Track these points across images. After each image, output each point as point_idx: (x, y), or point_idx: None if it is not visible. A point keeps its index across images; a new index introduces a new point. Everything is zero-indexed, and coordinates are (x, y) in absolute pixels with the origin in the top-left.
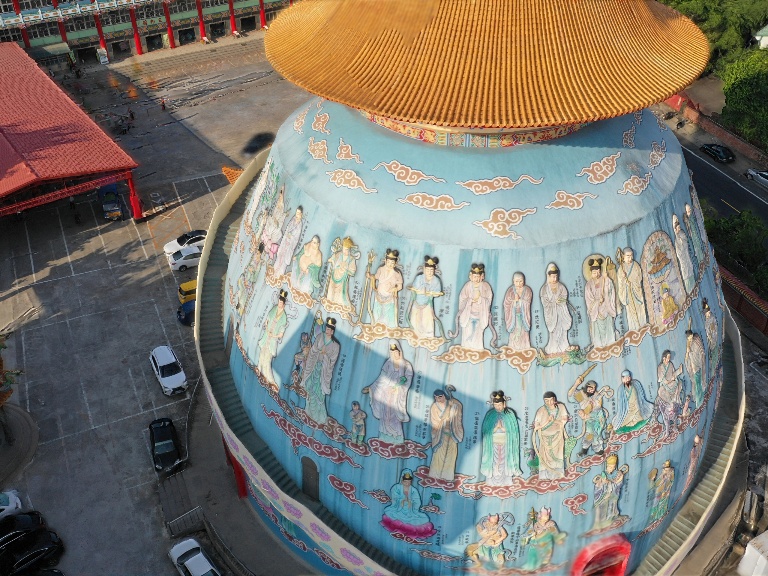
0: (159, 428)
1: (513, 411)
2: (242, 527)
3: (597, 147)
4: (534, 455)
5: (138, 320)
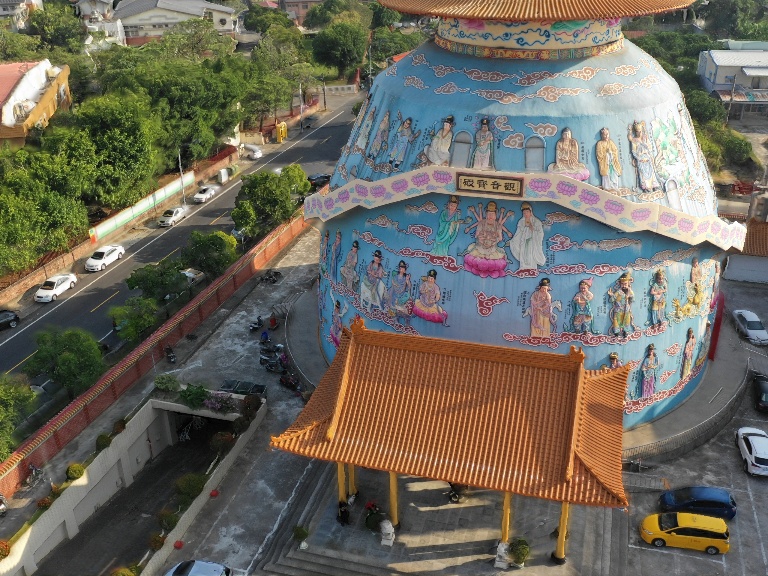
0: None
1: None
2: None
3: None
4: None
5: None
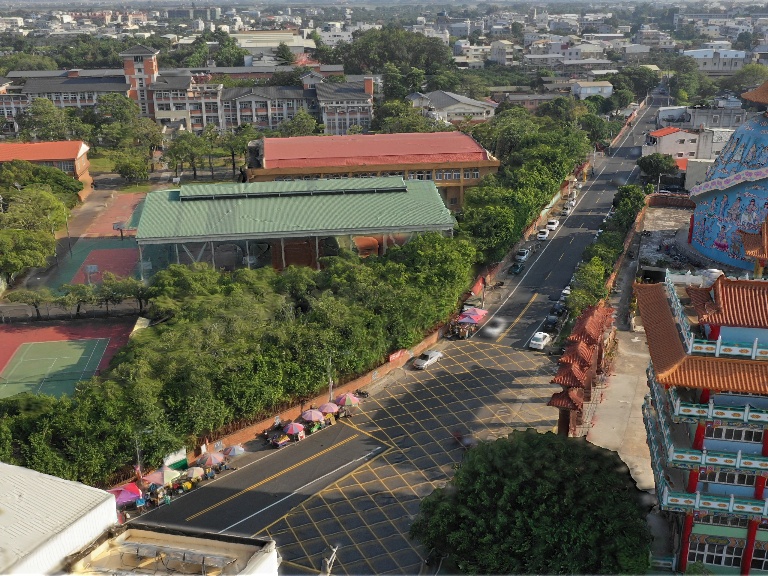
0: None
1: None
2: None
3: None
4: None
5: None
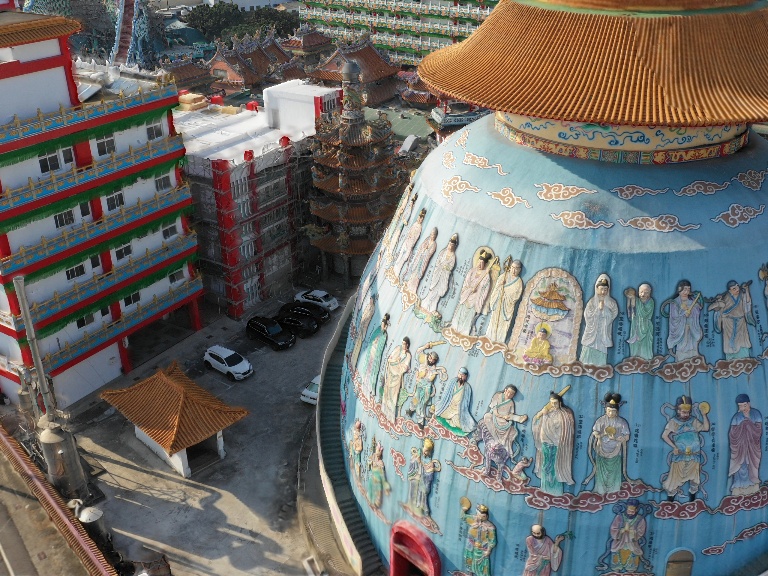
0: None
1: (387, 336)
2: None
3: (578, 175)
4: (384, 385)
5: None
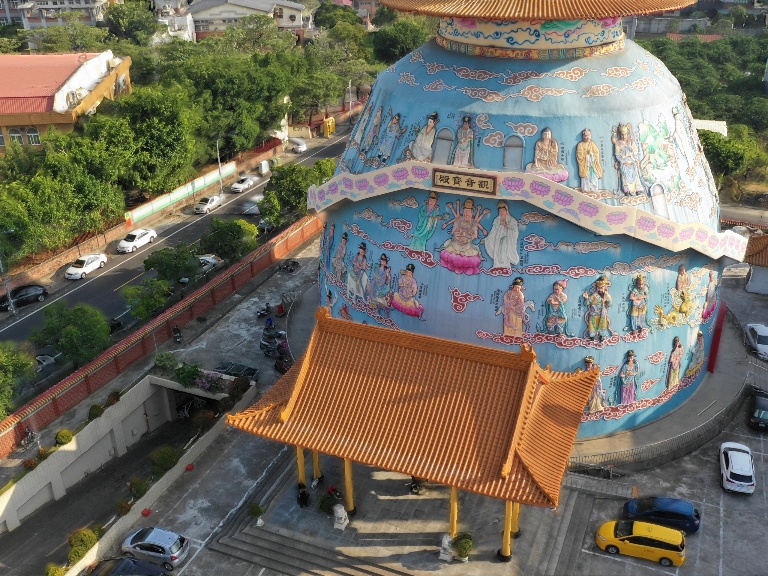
0: (767, 409)
1: None
2: (722, 341)
3: None
4: None
5: (754, 568)
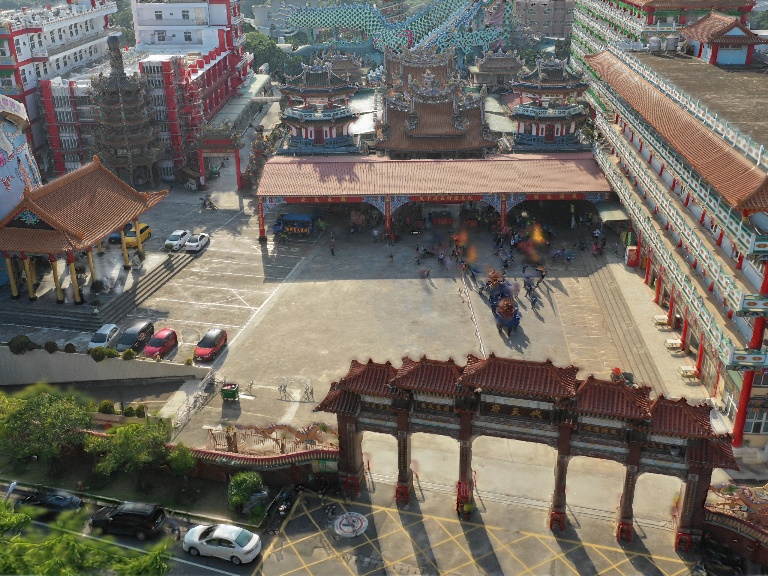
0: None
1: None
2: None
3: None
4: None
5: None
